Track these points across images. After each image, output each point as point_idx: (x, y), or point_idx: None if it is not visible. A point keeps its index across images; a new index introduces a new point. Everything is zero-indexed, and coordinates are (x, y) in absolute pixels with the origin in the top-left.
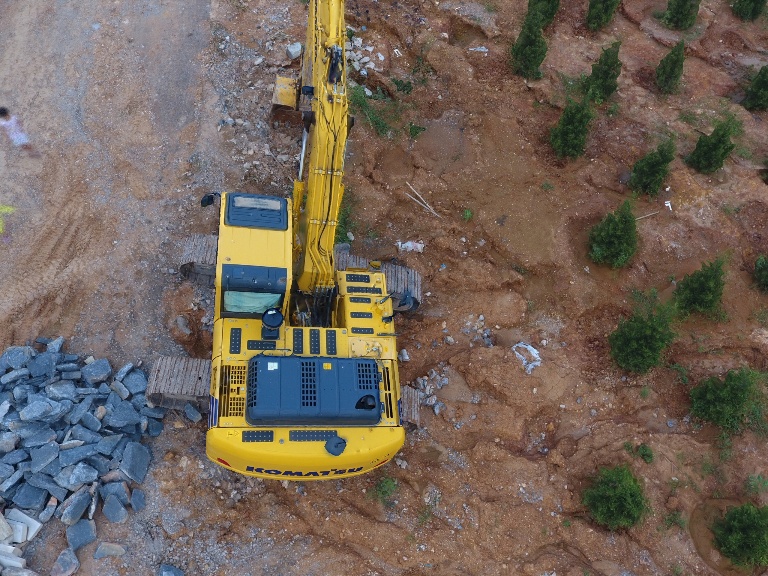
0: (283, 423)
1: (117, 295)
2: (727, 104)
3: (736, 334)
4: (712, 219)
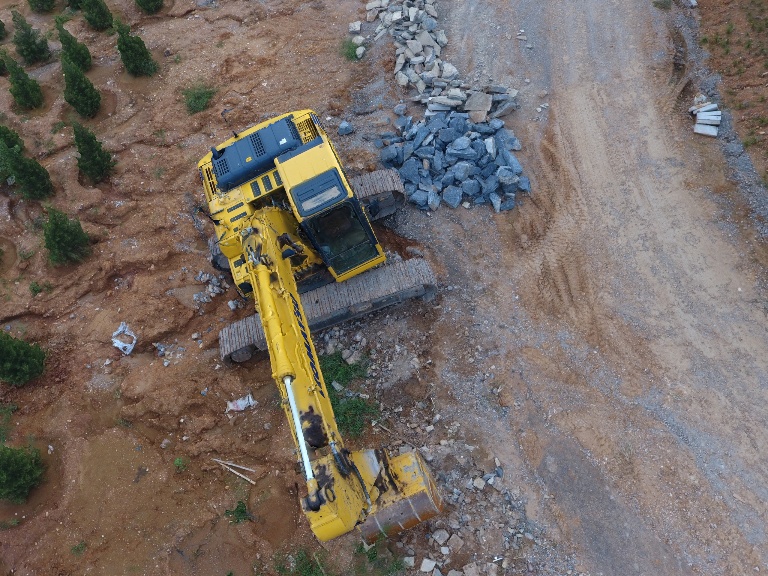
0: None
1: (483, 256)
2: None
3: None
4: None
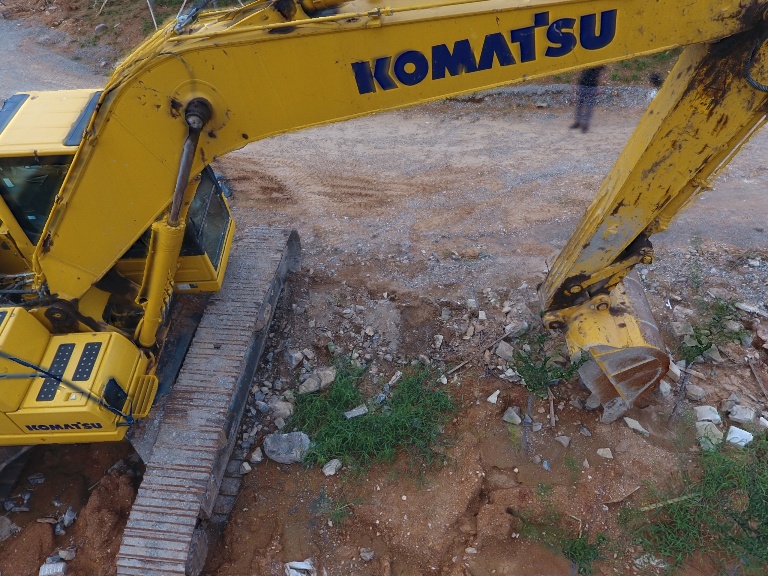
0: None
1: None
2: None
3: None
4: None
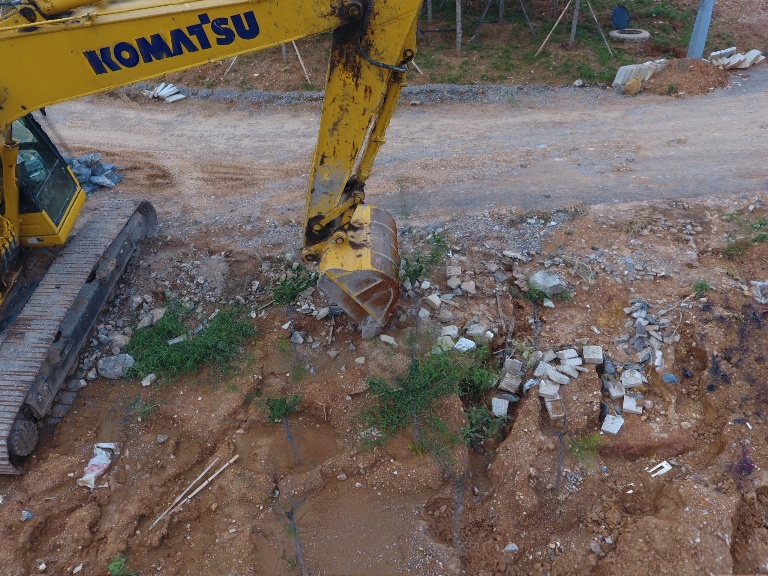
0: None
1: None
2: None
3: None
4: None
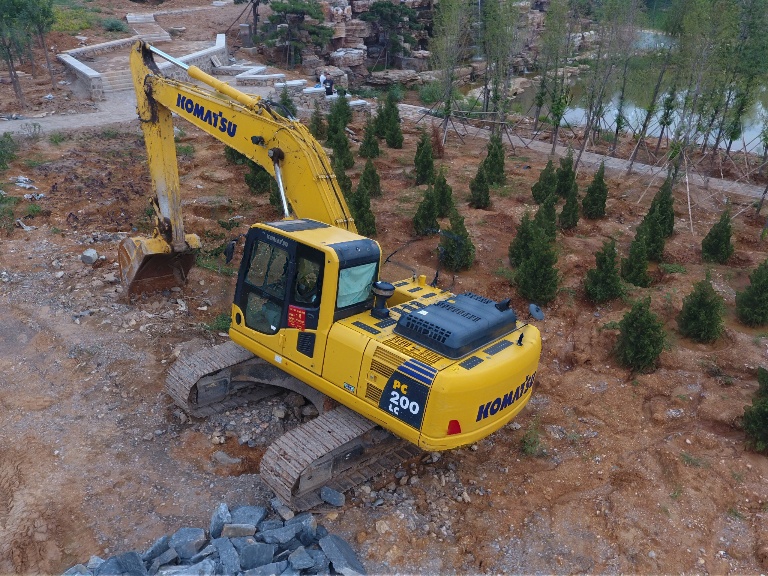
0: (474, 347)
1: (116, 486)
2: (415, 188)
3: (561, 265)
4: (478, 231)
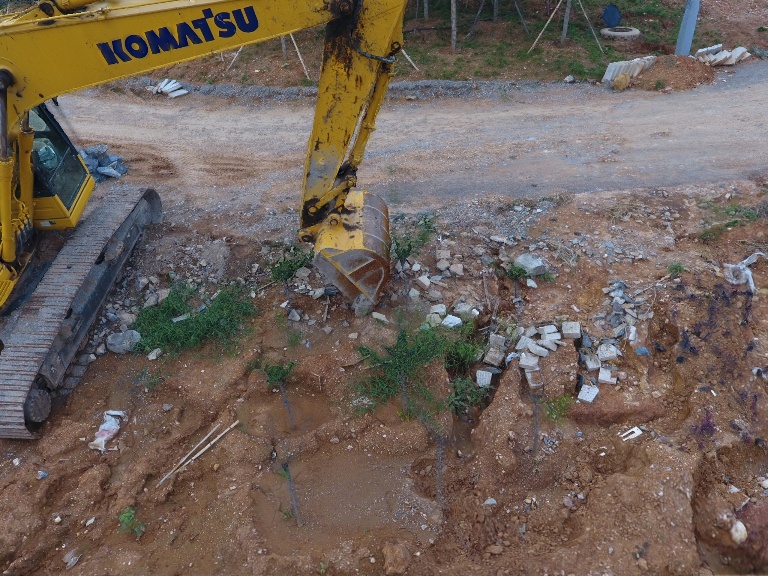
0: None
1: None
2: None
3: None
4: None
